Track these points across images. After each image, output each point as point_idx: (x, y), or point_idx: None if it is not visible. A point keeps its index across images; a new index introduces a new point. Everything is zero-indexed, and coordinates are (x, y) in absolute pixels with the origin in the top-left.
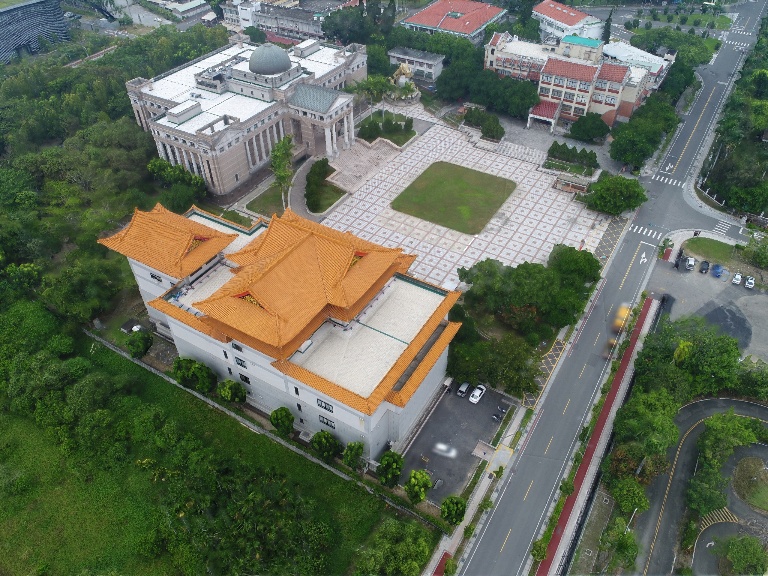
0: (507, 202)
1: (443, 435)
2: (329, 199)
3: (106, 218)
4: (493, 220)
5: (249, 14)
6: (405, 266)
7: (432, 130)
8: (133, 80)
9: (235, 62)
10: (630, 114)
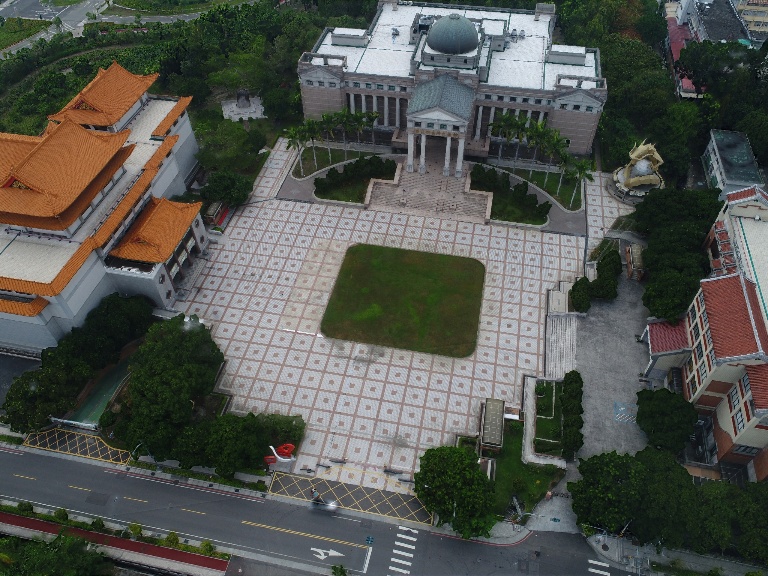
0: (413, 353)
1: None
2: (343, 194)
3: (229, 79)
4: (362, 346)
5: (686, 1)
6: (148, 258)
7: (564, 238)
8: None
9: None
10: (761, 479)
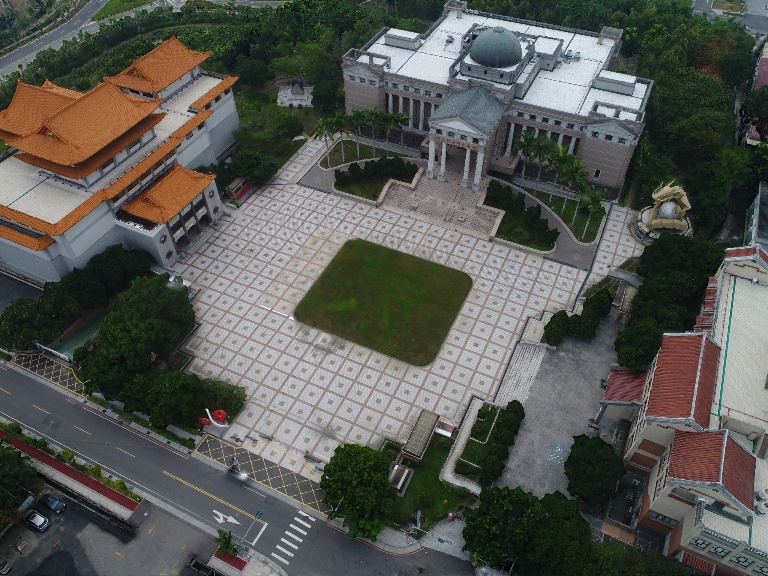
0: (372, 352)
1: (9, 295)
2: (360, 190)
3: (289, 66)
4: (327, 335)
5: None
6: (152, 217)
7: (565, 268)
8: (460, 1)
9: (523, 39)
10: (670, 553)
